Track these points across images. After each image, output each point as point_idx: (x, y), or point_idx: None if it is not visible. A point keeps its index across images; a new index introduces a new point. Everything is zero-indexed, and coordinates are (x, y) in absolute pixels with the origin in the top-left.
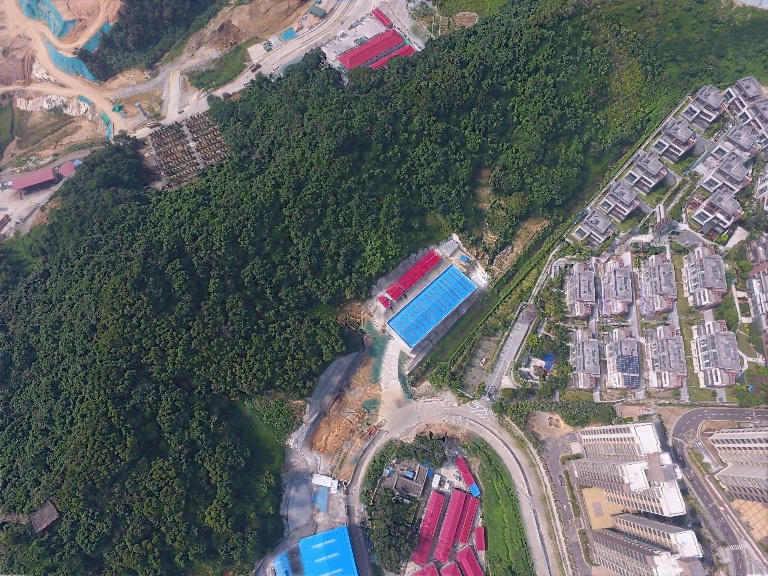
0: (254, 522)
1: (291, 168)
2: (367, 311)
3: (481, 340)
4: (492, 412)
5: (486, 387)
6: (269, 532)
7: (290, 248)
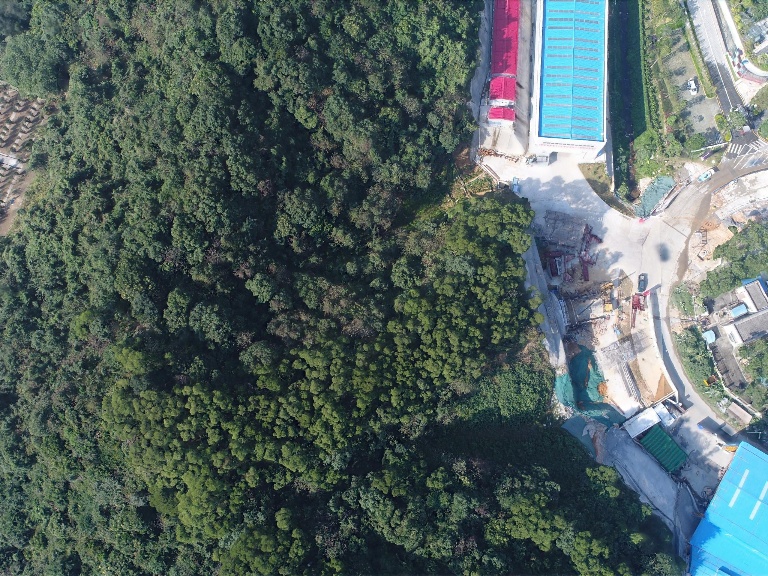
0: (642, 546)
1: (206, 8)
2: (483, 153)
3: (663, 63)
4: (763, 141)
5: (727, 117)
6: (668, 540)
7: (311, 142)
